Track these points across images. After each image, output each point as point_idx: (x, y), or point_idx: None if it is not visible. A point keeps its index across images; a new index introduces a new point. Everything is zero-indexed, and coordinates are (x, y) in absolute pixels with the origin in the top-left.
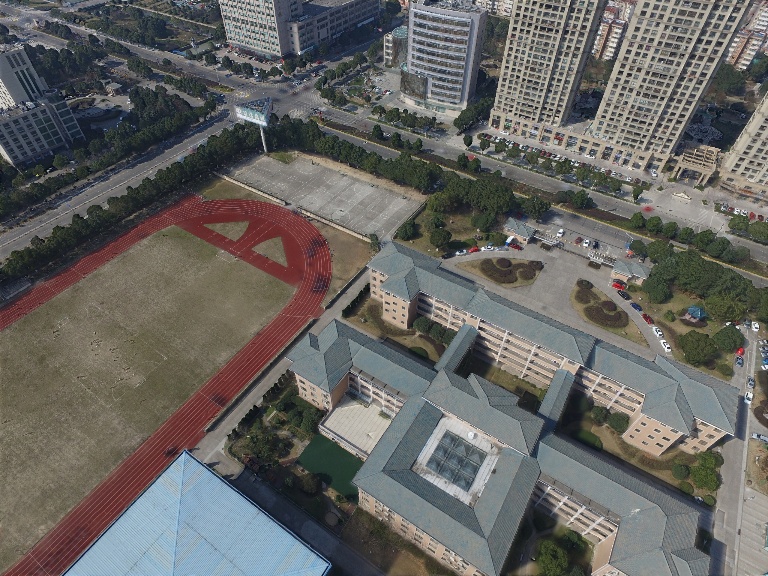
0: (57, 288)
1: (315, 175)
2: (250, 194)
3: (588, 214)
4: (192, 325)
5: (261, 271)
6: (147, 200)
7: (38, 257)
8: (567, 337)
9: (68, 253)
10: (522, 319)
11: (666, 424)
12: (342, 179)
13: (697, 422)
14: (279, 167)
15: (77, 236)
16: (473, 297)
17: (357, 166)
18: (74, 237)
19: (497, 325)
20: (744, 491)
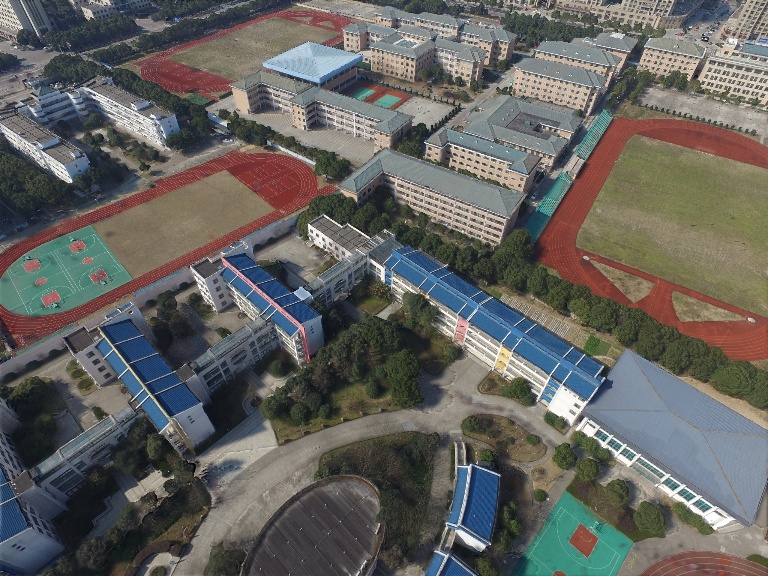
0: (229, 31)
1: (344, 5)
2: (312, 9)
3: (485, 16)
4: (295, 40)
5: (323, 29)
6: (262, 6)
7: (220, 17)
8: (453, 19)
9: (228, 23)
10: (436, 16)
11: (485, 40)
12: (359, 6)
13: (499, 43)
14: (325, 2)
15: (234, 13)
16: (418, 14)
17: (367, 2)
18: (233, 13)
19: (426, 19)
20: None
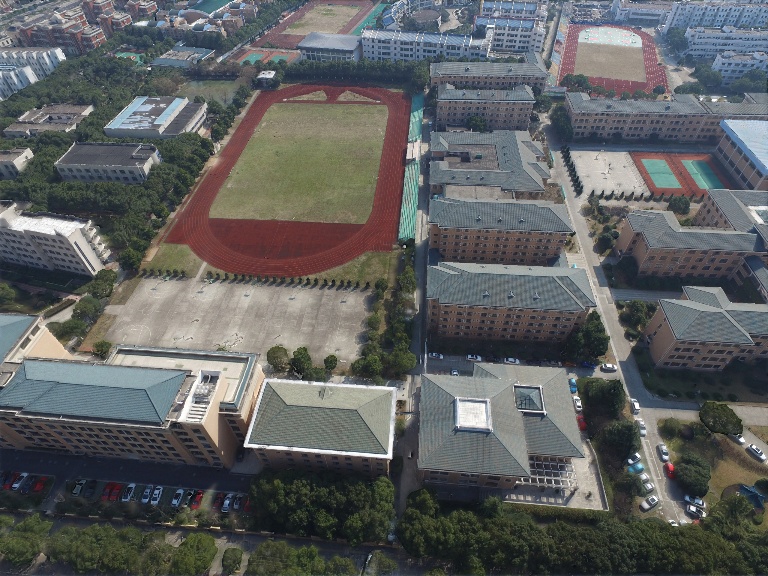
0: None
1: None
2: None
3: None
4: None
5: None
6: None
7: None
8: None
9: None
10: None
11: None
12: None
13: None
14: None
15: None
16: None
17: None
18: None
19: None
20: (604, 322)
